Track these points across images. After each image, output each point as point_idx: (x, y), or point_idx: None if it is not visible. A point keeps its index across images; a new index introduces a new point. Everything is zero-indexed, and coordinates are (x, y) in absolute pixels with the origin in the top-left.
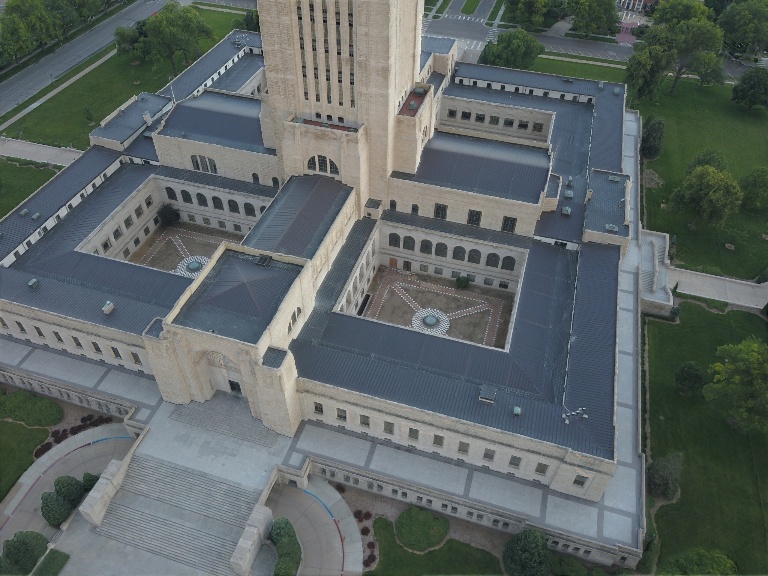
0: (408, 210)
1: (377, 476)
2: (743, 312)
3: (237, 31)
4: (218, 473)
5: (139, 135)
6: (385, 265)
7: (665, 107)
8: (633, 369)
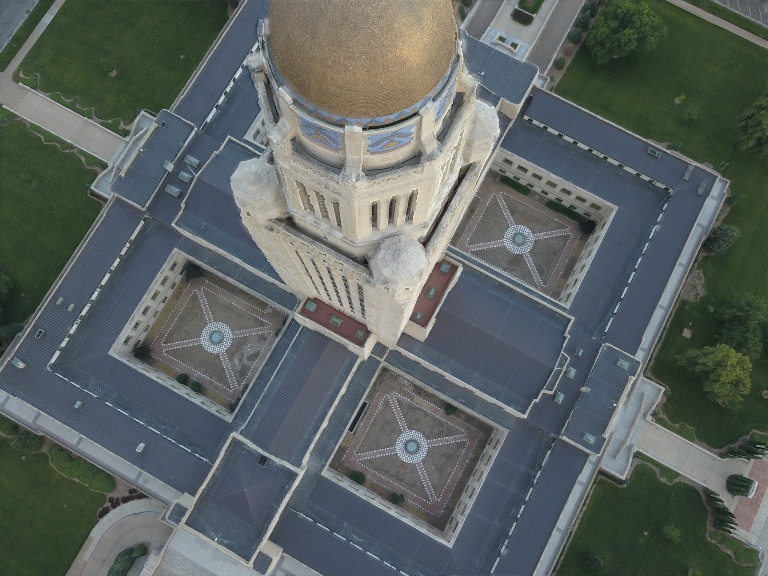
0: (412, 359)
1: None
2: (688, 486)
3: None
4: None
5: (161, 185)
6: (387, 369)
7: None
8: (556, 547)
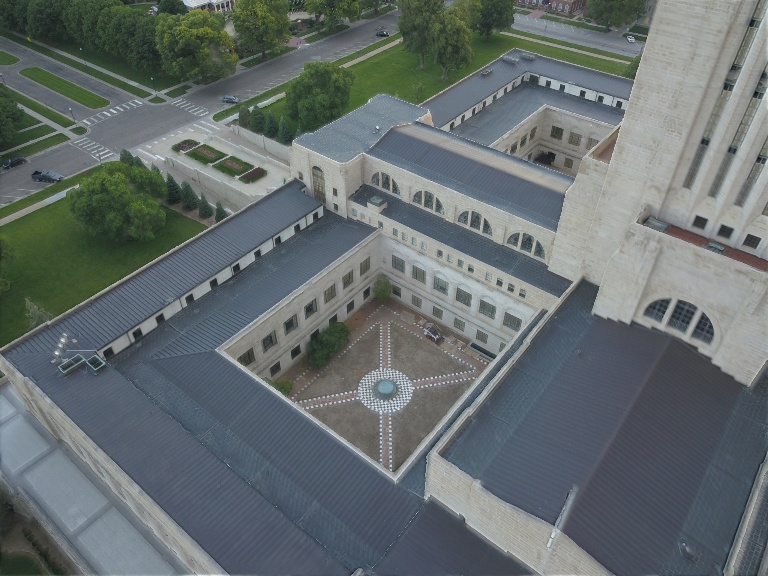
0: None
1: None
2: None
3: (7, 351)
4: None
5: None
6: None
7: (463, 68)
8: None
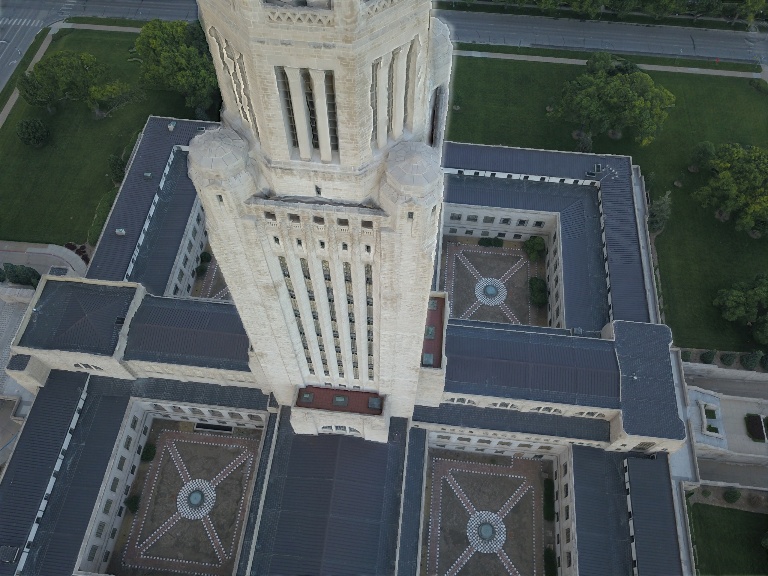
0: None
1: None
2: None
3: (629, 160)
4: None
5: None
6: None
7: None
8: None
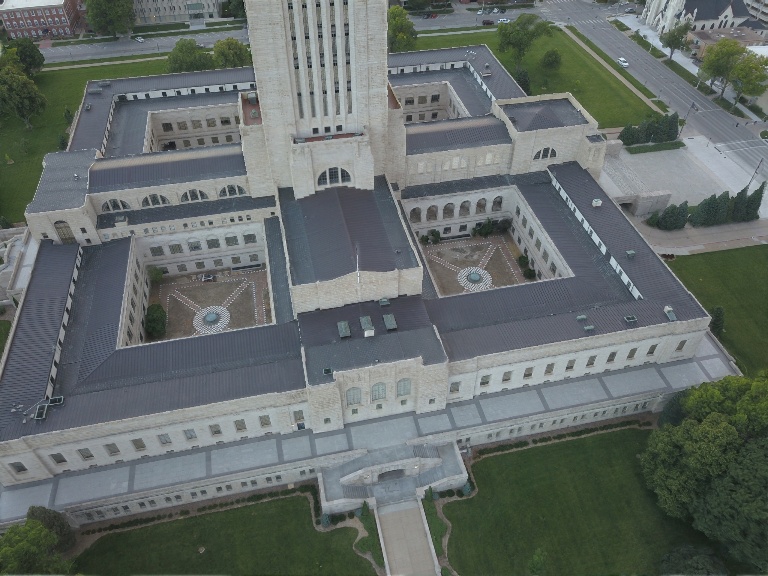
0: None
1: None
2: None
3: None
4: None
5: None
6: None
7: None
8: None
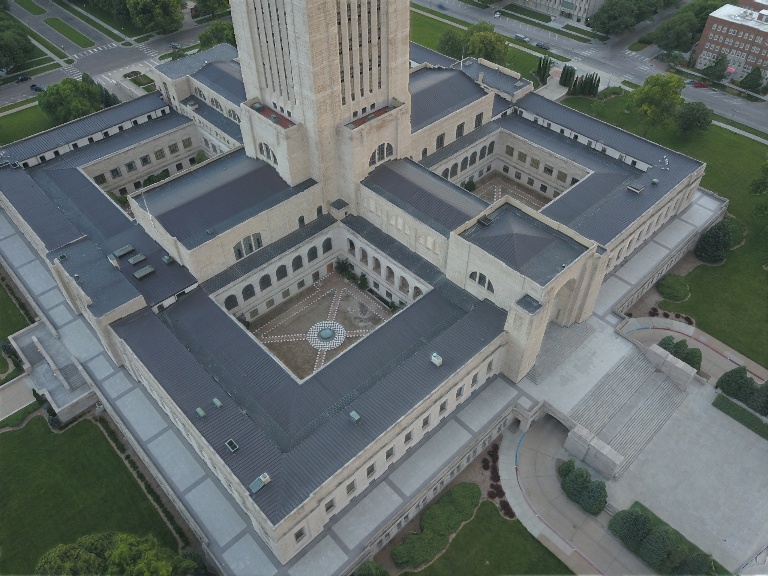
0: (420, 157)
1: (644, 281)
2: (564, 100)
3: None
4: (609, 366)
5: None
6: None
7: None
8: None
